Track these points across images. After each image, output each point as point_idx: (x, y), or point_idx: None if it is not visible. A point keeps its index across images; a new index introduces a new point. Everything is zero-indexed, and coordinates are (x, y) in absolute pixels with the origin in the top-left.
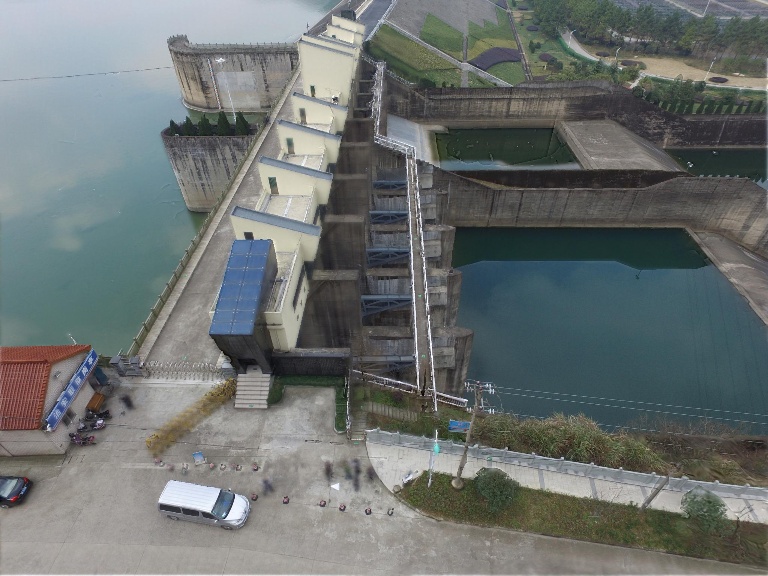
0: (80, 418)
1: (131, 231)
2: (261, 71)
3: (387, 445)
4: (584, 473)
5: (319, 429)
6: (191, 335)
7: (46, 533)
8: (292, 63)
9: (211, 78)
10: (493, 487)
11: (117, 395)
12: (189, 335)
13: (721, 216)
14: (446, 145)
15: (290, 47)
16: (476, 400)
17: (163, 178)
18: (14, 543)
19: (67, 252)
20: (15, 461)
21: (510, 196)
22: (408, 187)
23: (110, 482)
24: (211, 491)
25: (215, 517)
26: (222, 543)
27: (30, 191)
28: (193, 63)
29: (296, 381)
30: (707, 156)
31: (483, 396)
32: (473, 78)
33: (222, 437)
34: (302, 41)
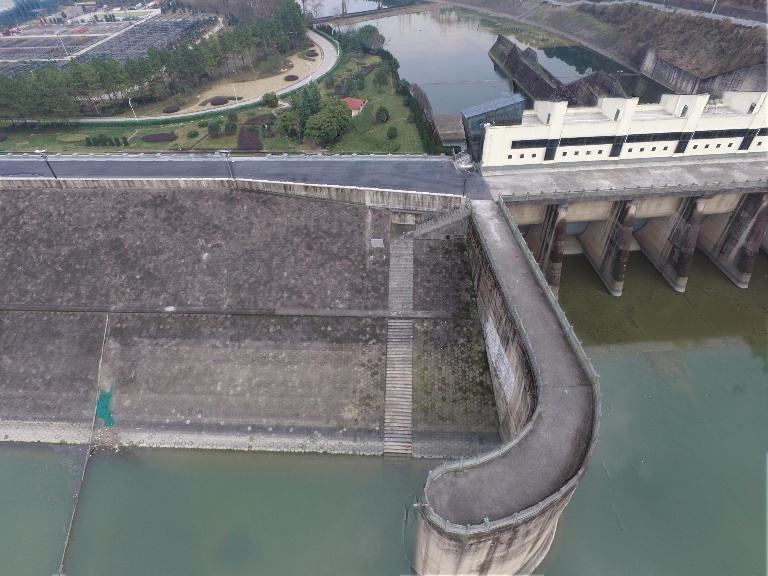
0: None
1: None
2: None
3: None
4: None
5: None
6: None
7: None
8: None
9: None
10: None
11: None
12: None
13: None
14: None
15: None
16: None
17: None
18: None
19: None
20: None
21: None
22: None
23: None
24: None
25: None
26: None
27: None
28: None
29: None
30: None
31: None
32: None
33: None
34: None
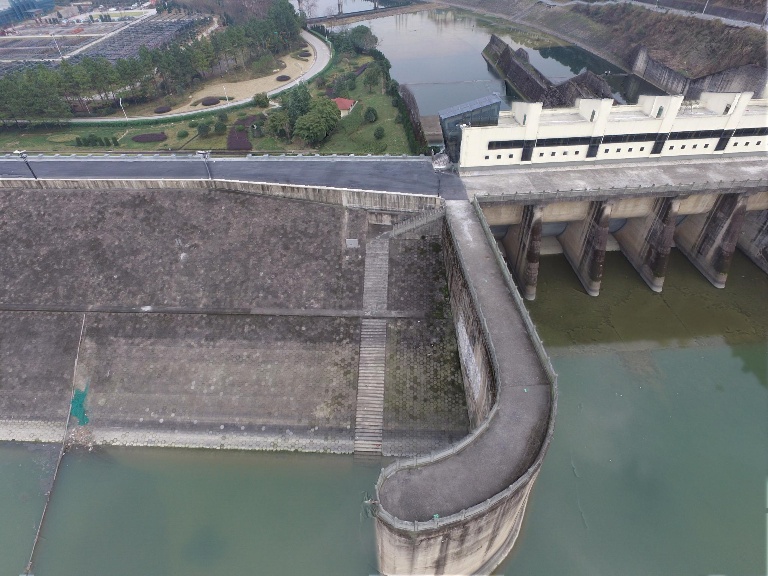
0: None
1: None
2: None
3: None
4: None
5: None
6: None
7: None
8: None
9: None
10: None
11: None
12: None
13: None
14: None
15: None
16: None
17: None
18: None
19: None
20: None
21: None
22: None
23: None
24: None
25: None
26: None
27: None
28: None
29: None
30: None
31: None
32: None
33: None
34: None
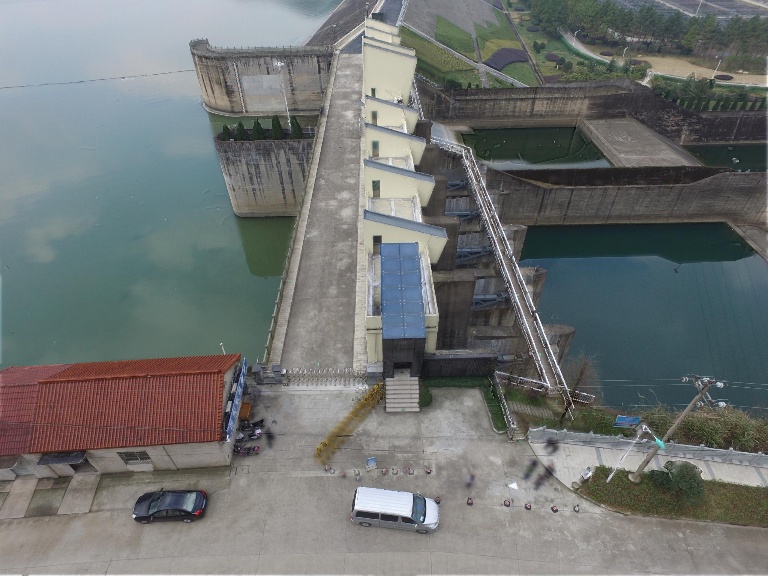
0: (236, 428)
1: (181, 238)
2: (287, 74)
3: (550, 443)
4: (749, 462)
5: (477, 430)
6: (316, 341)
7: (238, 546)
8: (319, 66)
9: (236, 82)
10: (689, 479)
11: (262, 404)
12: (314, 341)
13: (761, 209)
14: (473, 145)
15: (318, 50)
16: (702, 394)
17: (201, 184)
18: (208, 557)
19: (120, 261)
20: (181, 474)
21: (560, 194)
22: (475, 188)
23: (286, 491)
24: (405, 496)
25: (415, 521)
26: (421, 547)
27: (66, 200)
28: (218, 67)
29: (441, 383)
30: (722, 152)
31: (709, 390)
32: (491, 79)
33: (383, 442)
34: (365, 44)
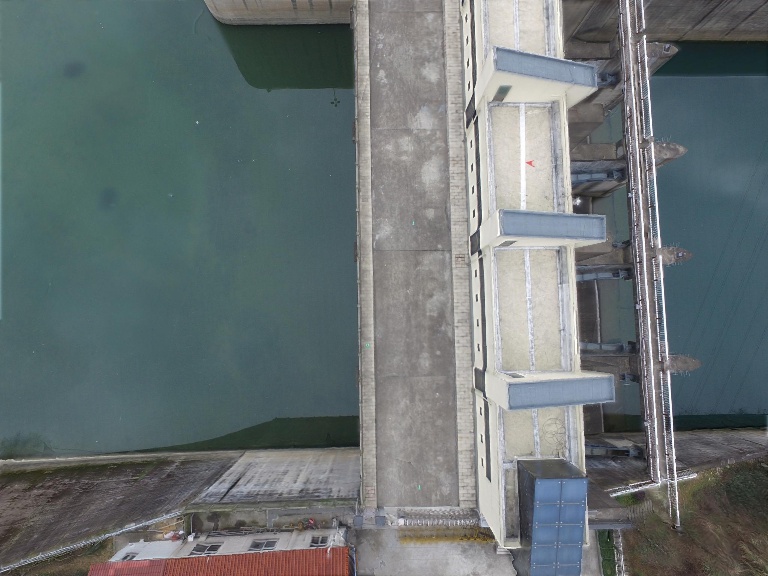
0: None
1: (142, 74)
2: None
3: None
4: None
5: (585, 572)
6: (413, 452)
7: None
8: None
9: None
10: None
11: (365, 541)
12: (411, 452)
13: None
14: None
15: None
16: None
17: None
18: None
19: (67, 126)
20: None
21: (746, 3)
22: (631, 69)
23: None
24: None
25: None
26: None
27: None
28: None
29: None
30: None
31: None
32: None
33: None
34: None
